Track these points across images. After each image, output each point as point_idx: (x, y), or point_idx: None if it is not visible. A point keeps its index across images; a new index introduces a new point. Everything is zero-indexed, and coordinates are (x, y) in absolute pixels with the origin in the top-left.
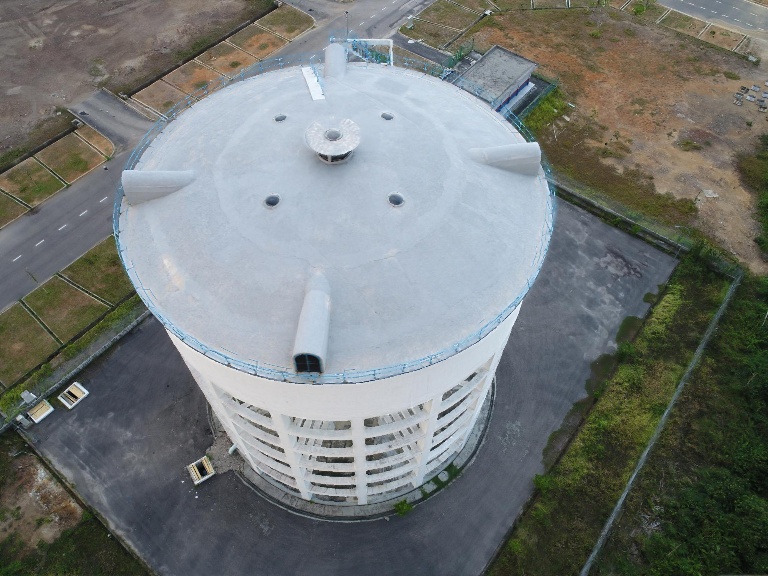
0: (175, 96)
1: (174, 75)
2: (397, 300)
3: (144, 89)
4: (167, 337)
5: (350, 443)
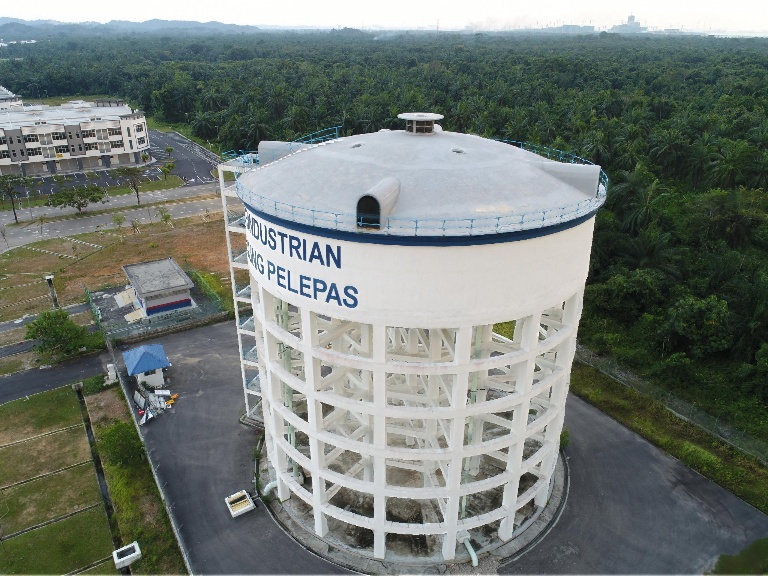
0: None
1: None
2: None
3: None
4: None
5: (491, 461)
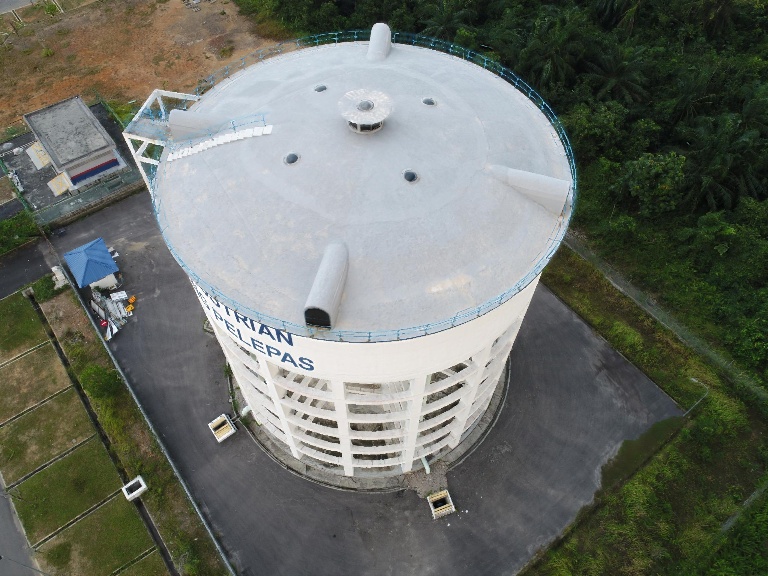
0: None
1: None
2: (516, 135)
3: None
4: (268, 535)
5: None
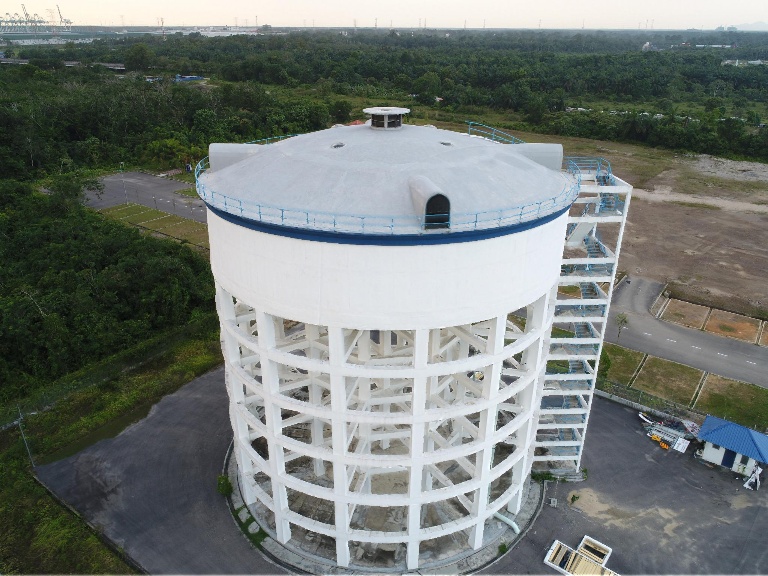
0: (695, 317)
1: (725, 313)
2: None
3: (688, 303)
4: None
5: None
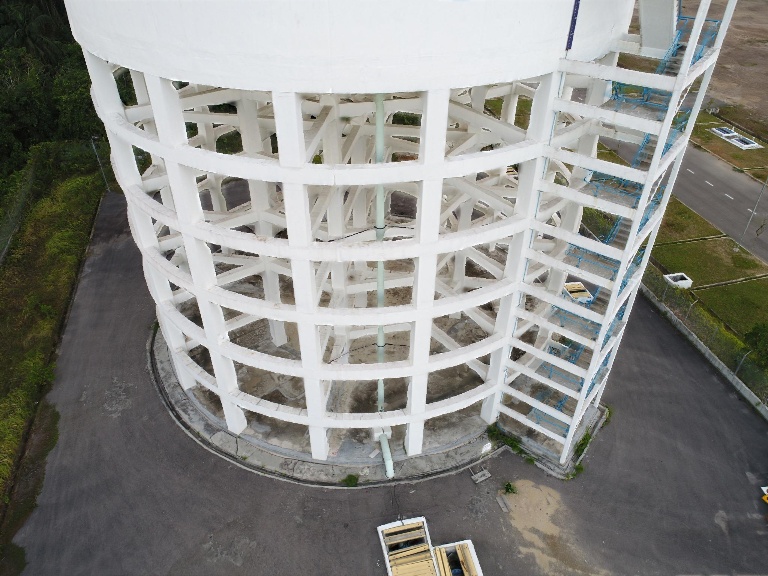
0: None
1: None
2: None
3: None
4: None
5: None
